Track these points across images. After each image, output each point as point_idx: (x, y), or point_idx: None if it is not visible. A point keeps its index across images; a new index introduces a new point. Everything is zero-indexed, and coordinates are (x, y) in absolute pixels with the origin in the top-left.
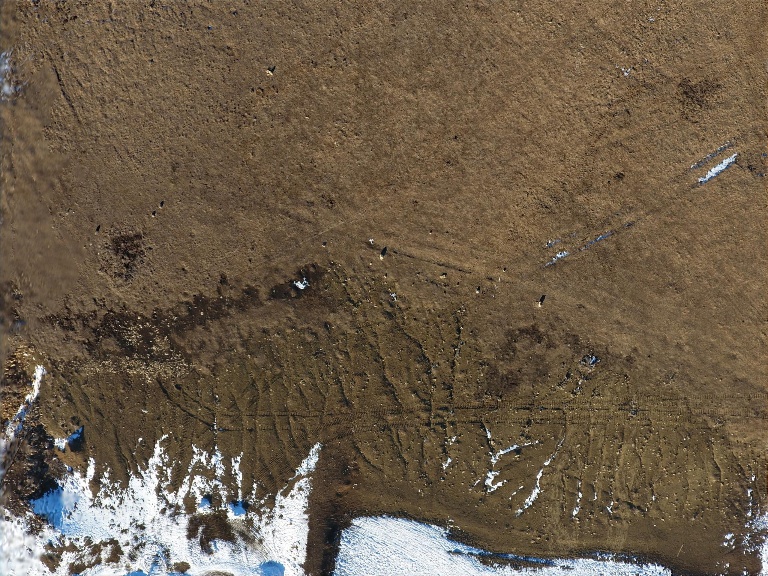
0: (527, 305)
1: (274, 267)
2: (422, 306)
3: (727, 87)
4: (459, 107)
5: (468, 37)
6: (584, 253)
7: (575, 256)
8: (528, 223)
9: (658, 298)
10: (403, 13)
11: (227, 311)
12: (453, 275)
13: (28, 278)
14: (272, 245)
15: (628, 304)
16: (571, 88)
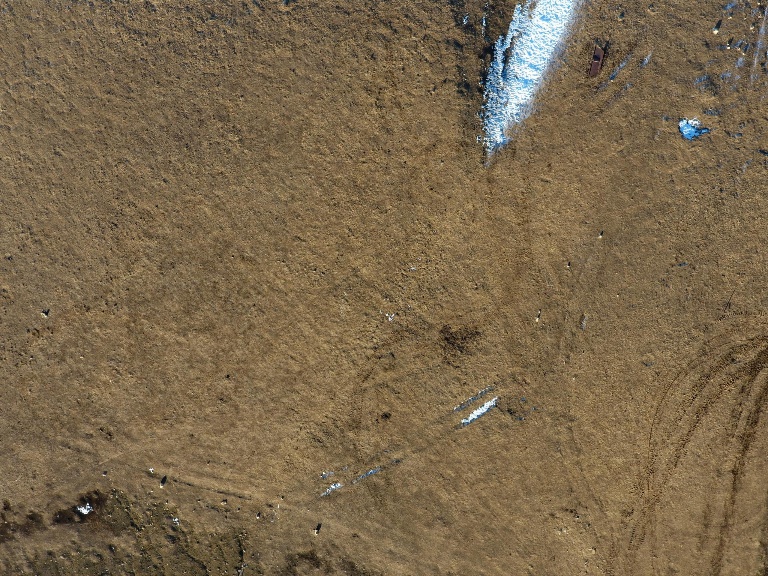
0: (305, 532)
1: (57, 494)
2: (204, 530)
3: (486, 334)
4: (230, 348)
5: (235, 284)
6: (356, 486)
7: (347, 488)
8: (302, 455)
9: (428, 531)
10: (171, 262)
11: (12, 535)
12: (234, 501)
13: None
14: (53, 474)
15: (400, 535)
16: (337, 332)
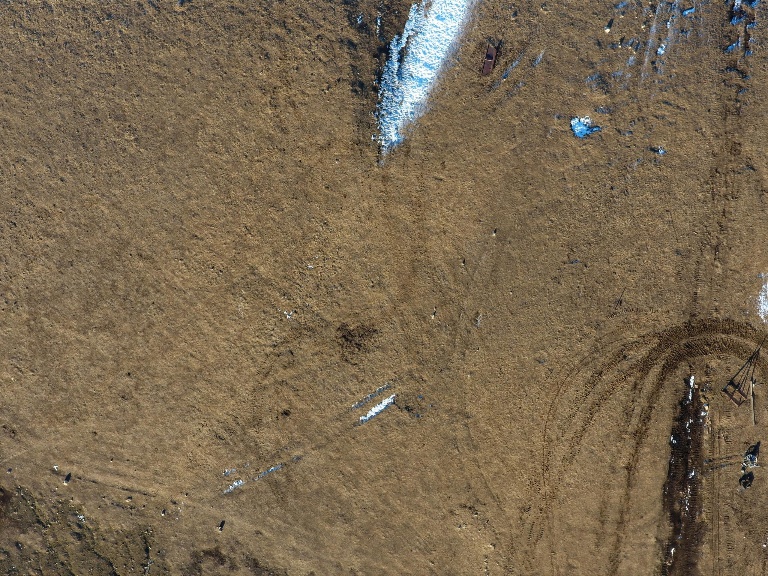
0: (209, 529)
1: None
2: (110, 527)
3: (383, 332)
4: (130, 346)
5: (133, 283)
6: (257, 483)
7: (249, 486)
8: (205, 453)
9: (329, 527)
10: (69, 261)
11: None
12: (138, 498)
13: None
14: None
15: (302, 532)
16: (236, 330)
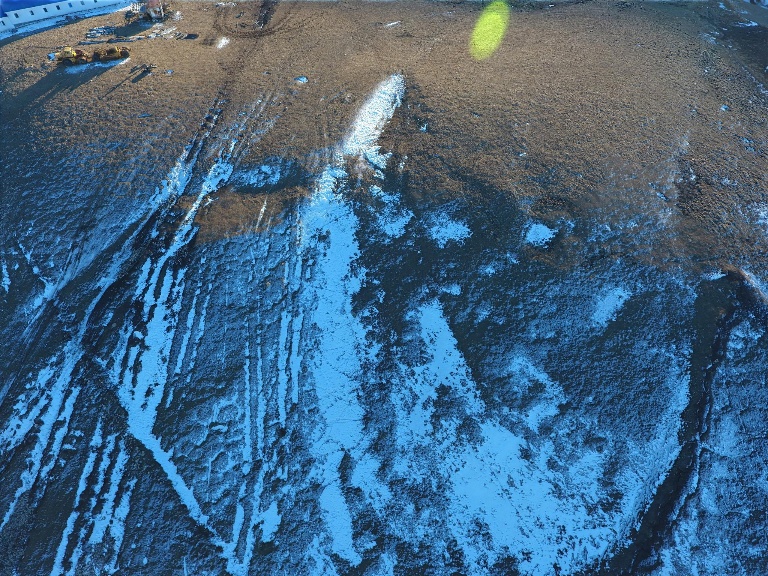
0: (459, 6)
1: None
2: None
3: None
4: None
5: None
6: None
7: None
8: None
9: None
10: None
11: None
12: None
13: (663, 3)
14: None
15: None
16: None
